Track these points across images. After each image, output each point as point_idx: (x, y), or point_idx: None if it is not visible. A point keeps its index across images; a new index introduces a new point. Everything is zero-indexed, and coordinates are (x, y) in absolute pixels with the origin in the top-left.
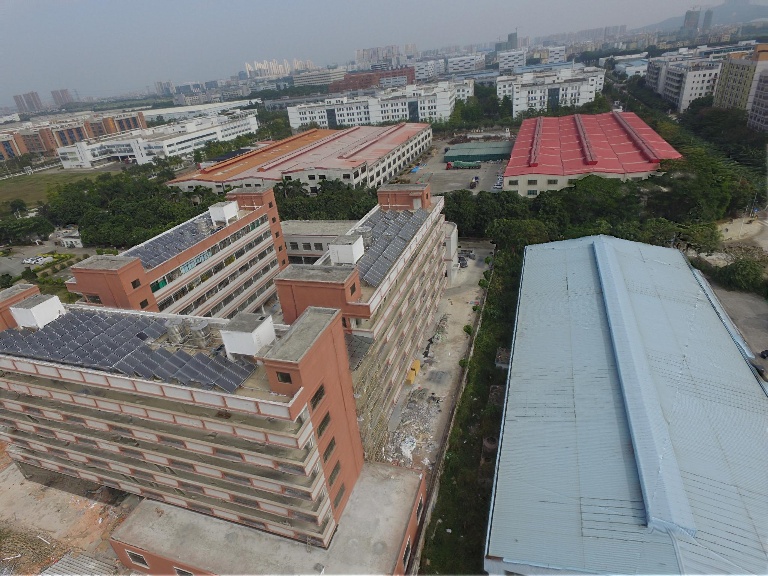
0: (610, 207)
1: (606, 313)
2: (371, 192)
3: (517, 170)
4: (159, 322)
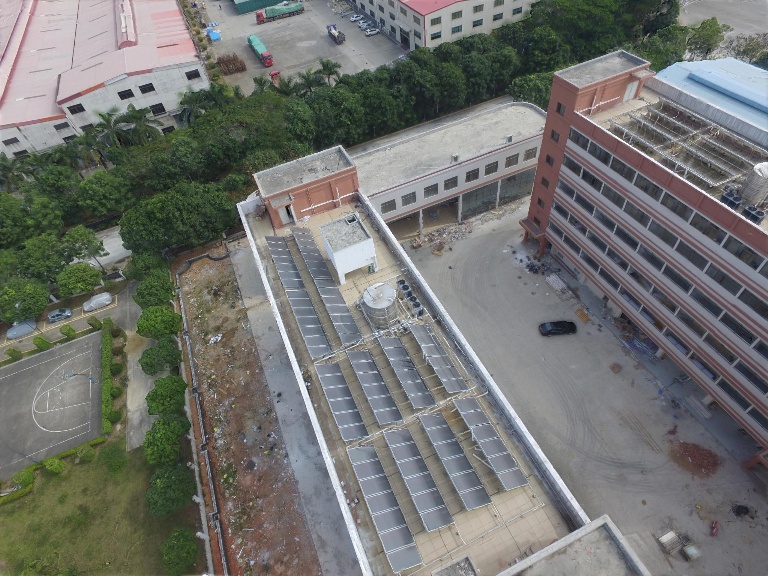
0: (607, 25)
1: None
2: (277, 90)
3: (427, 2)
4: None
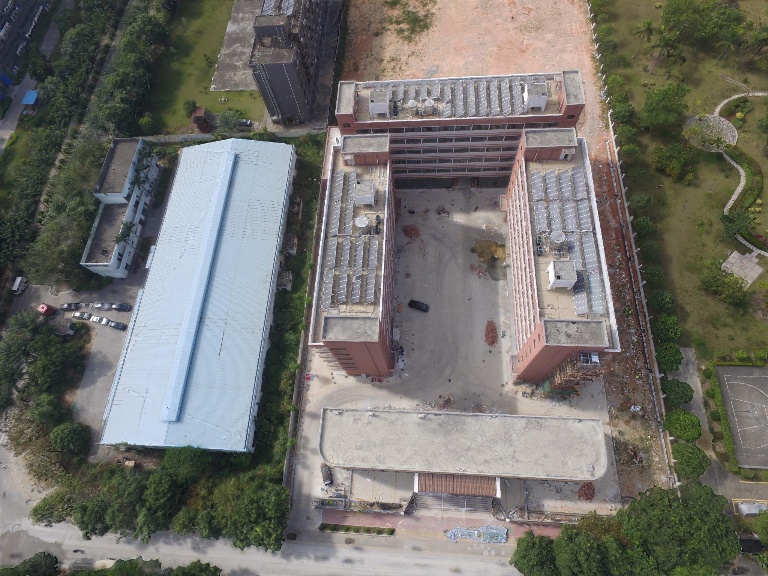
0: None
1: (207, 287)
2: None
3: None
4: (449, 113)
